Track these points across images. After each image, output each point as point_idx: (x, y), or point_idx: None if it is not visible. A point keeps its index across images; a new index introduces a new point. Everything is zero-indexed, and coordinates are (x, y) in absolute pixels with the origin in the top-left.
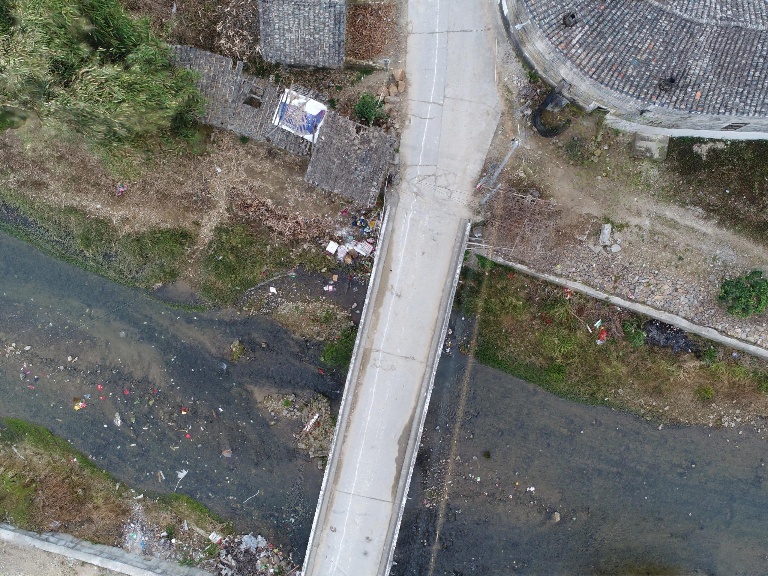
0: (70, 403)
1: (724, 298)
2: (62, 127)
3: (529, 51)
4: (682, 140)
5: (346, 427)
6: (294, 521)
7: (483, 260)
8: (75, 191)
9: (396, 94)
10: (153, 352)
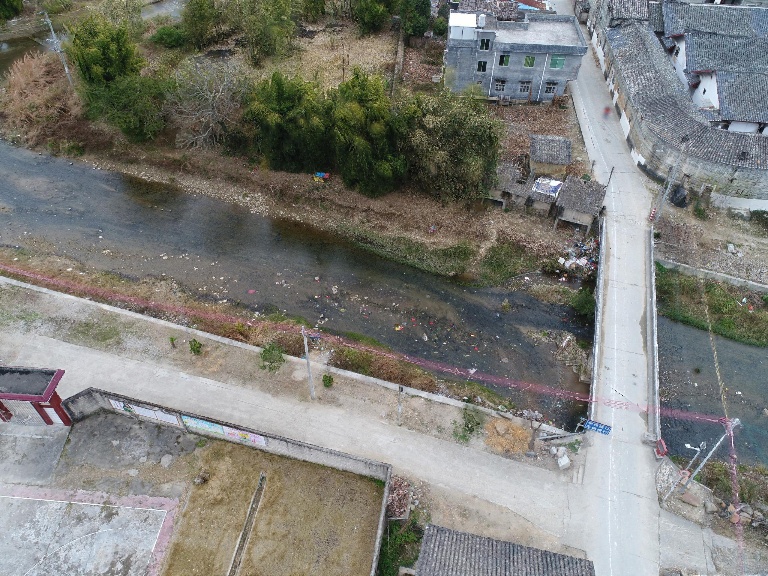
0: (392, 327)
1: None
2: (404, 202)
3: (662, 170)
4: (756, 212)
5: (602, 314)
6: (561, 406)
7: (659, 265)
8: (404, 230)
9: None
10: (448, 306)
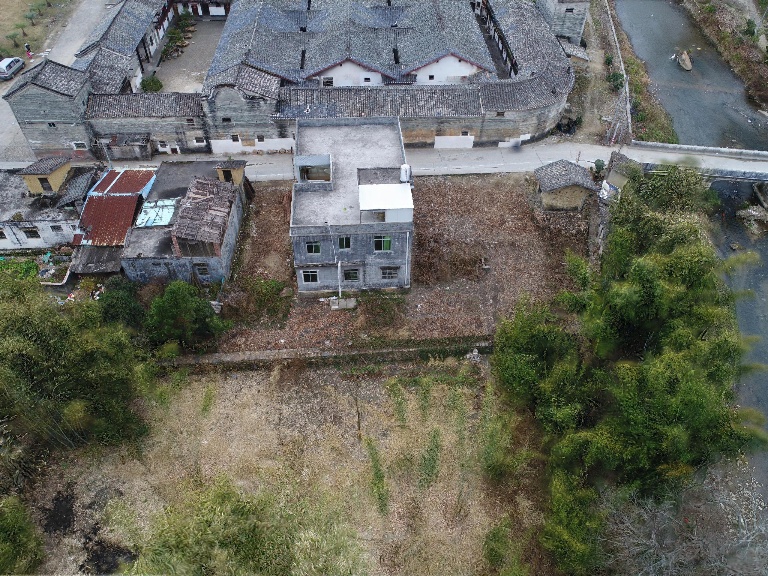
0: None
1: None
2: None
3: None
4: None
5: None
6: None
7: None
8: None
9: None
10: (764, 285)
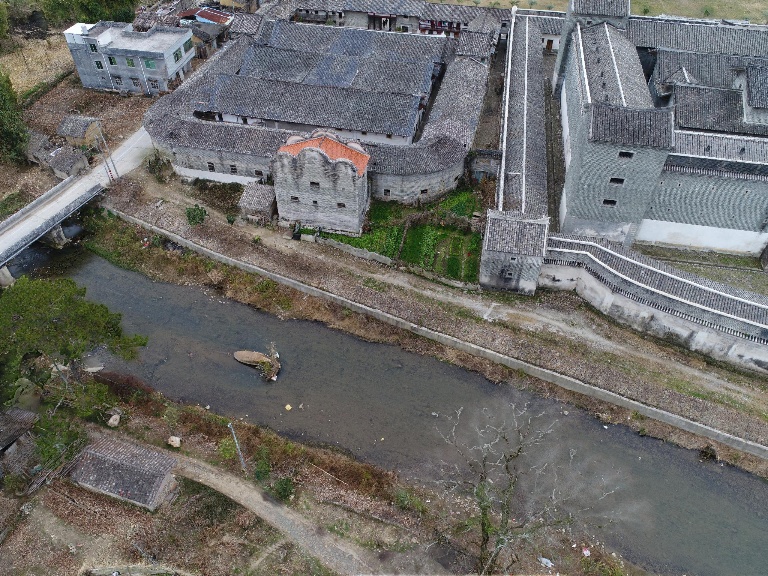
0: None
1: None
2: None
3: None
4: None
5: (0, 235)
6: None
7: (109, 213)
8: None
9: (103, 157)
10: None
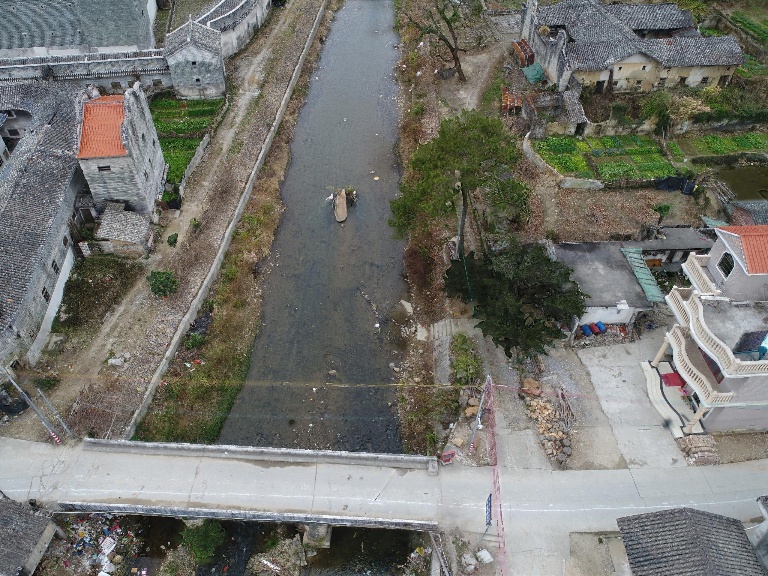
0: None
1: (164, 292)
2: None
3: None
4: (54, 327)
5: None
6: (369, 571)
7: None
8: None
9: None
10: None
